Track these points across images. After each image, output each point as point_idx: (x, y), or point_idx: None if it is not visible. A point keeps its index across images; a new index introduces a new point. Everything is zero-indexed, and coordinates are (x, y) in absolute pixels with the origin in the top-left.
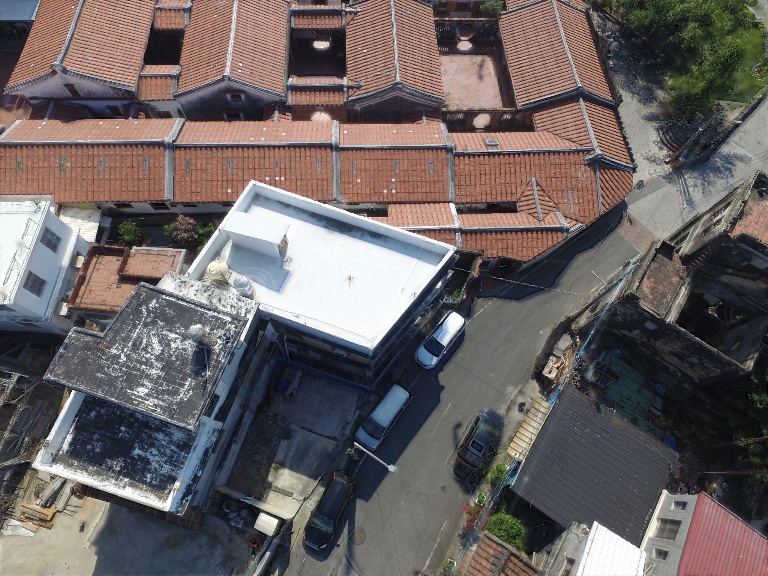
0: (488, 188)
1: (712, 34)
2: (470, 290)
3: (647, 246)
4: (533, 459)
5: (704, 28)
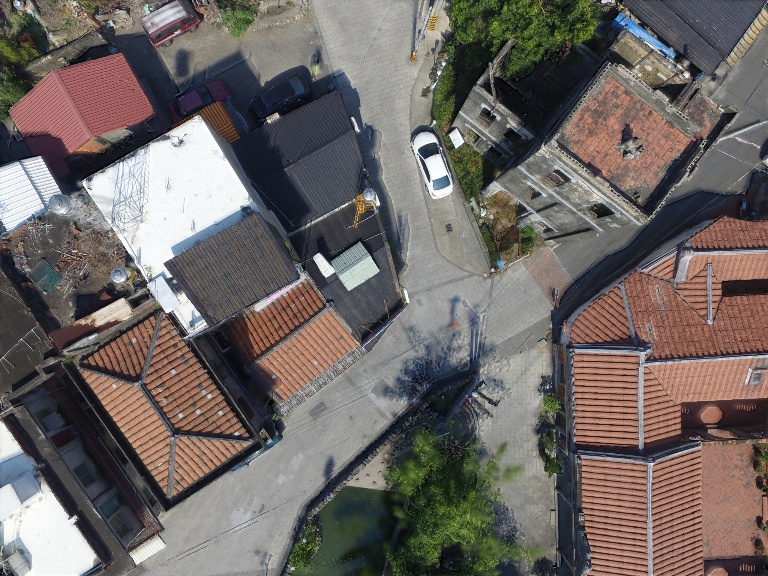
0: (761, 312)
1: (444, 573)
2: (750, 203)
3: (543, 259)
4: (759, 3)
5: (471, 575)
